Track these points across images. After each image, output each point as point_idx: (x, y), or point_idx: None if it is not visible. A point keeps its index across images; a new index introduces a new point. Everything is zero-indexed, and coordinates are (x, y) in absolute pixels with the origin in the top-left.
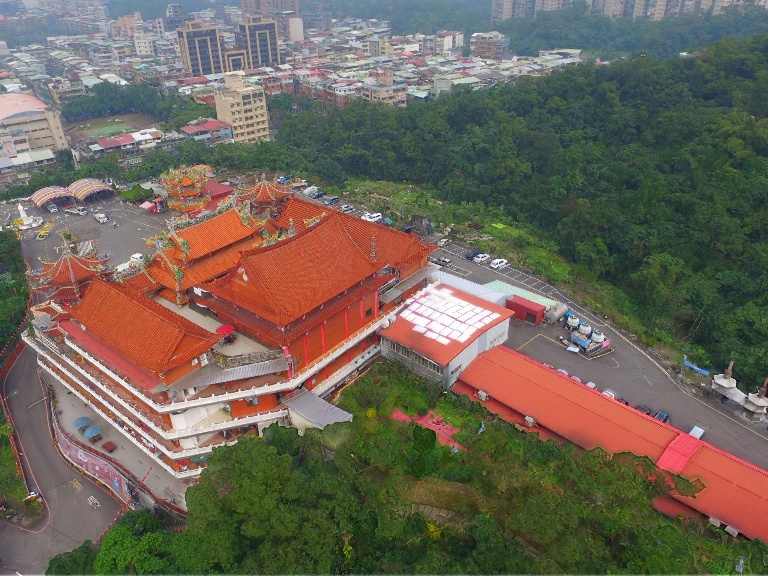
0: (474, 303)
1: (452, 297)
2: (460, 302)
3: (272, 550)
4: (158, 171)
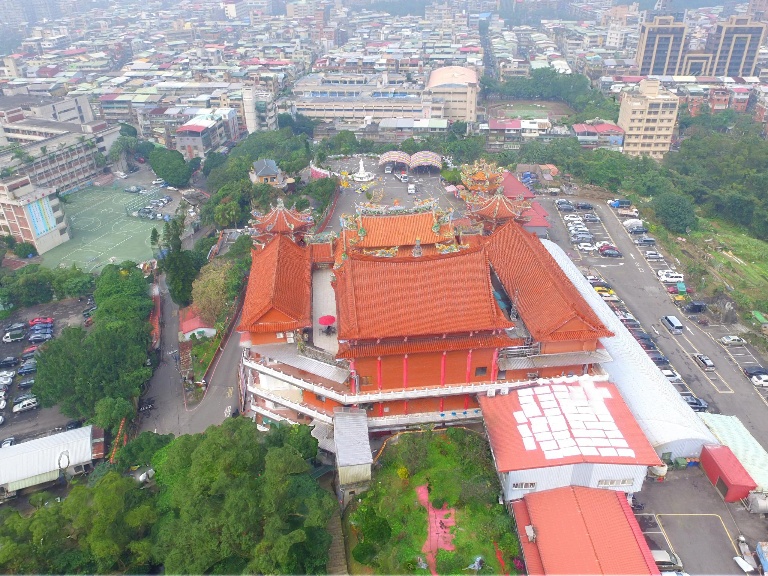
0: (620, 423)
1: (601, 402)
2: (603, 413)
3: (188, 526)
4: (511, 161)
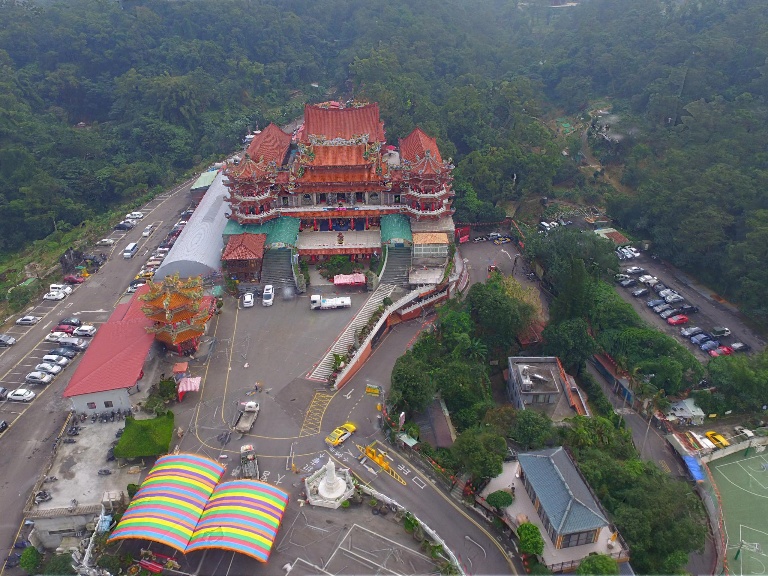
0: None
1: None
2: None
3: None
4: None
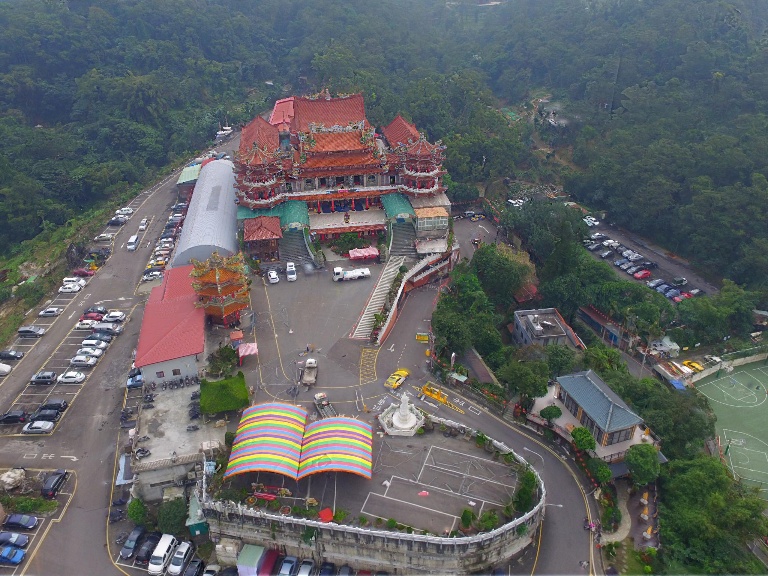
0: None
1: None
2: None
3: None
4: None
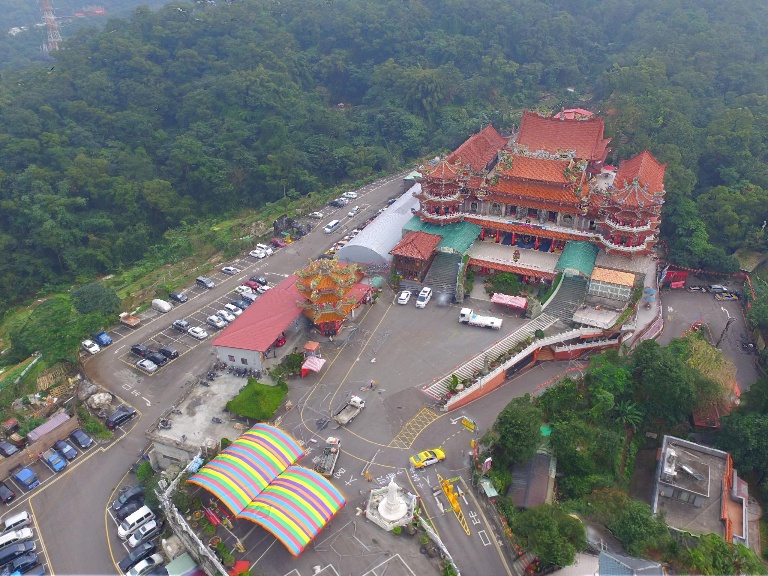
0: None
1: None
2: None
3: None
4: None
